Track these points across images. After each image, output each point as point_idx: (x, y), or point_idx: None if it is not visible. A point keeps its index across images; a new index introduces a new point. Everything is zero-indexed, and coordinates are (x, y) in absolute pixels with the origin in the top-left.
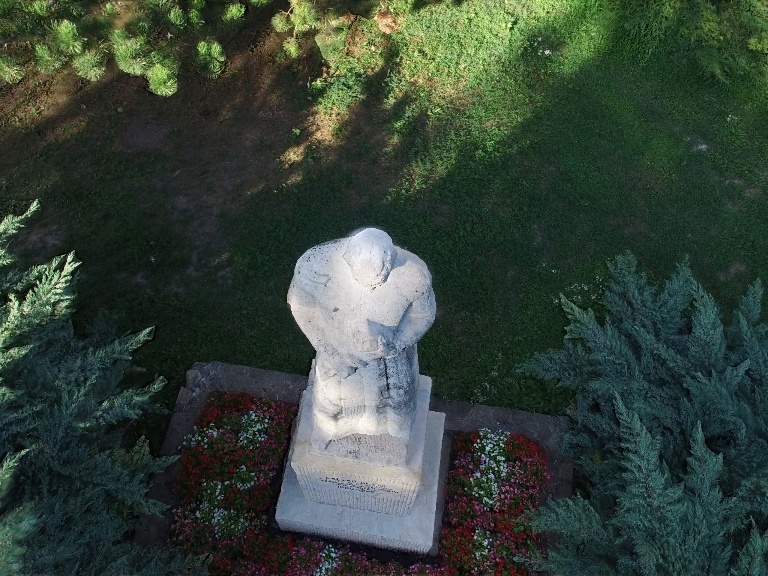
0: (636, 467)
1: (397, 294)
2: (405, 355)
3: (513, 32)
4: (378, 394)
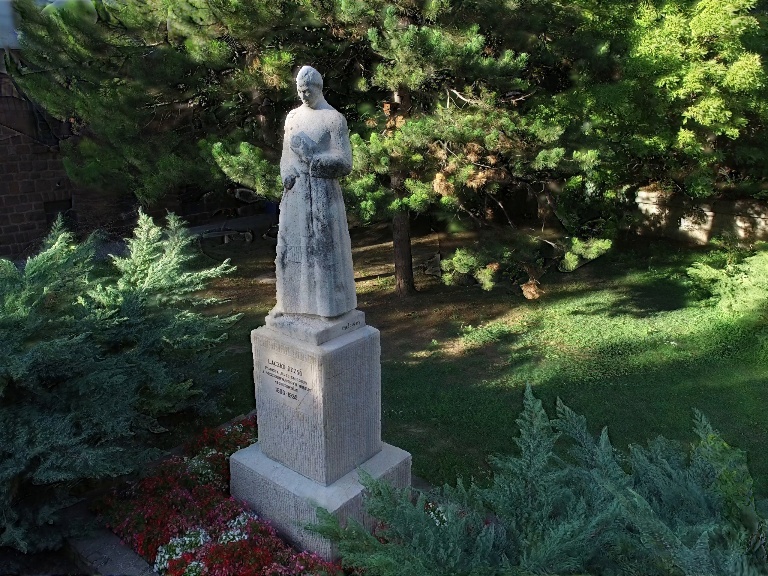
0: (525, 445)
1: (322, 120)
2: (325, 187)
3: (651, 335)
4: (307, 227)
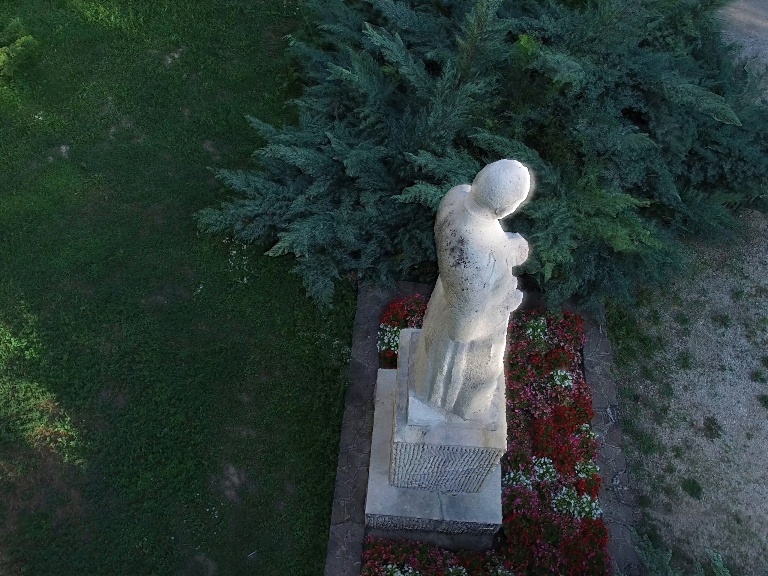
0: None
1: None
2: None
3: None
4: None
